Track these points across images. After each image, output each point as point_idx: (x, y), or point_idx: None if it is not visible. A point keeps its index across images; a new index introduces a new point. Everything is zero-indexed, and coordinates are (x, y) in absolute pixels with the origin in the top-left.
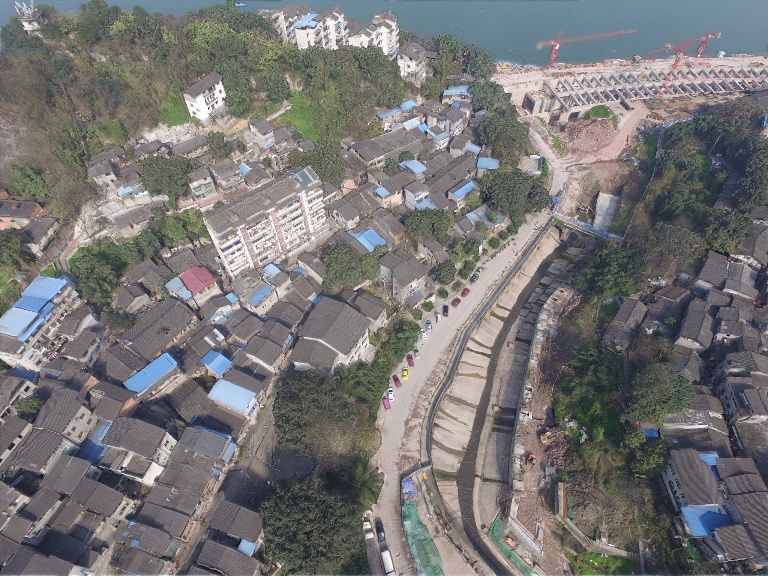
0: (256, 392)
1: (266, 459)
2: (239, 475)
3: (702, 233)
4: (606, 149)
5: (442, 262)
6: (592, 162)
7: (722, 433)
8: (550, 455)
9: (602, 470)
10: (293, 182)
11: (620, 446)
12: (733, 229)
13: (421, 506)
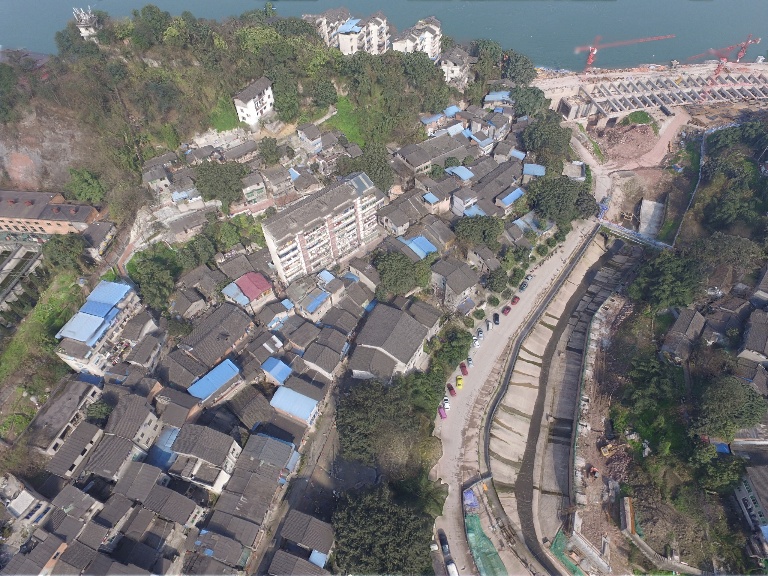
0: (318, 400)
1: (328, 468)
2: (302, 484)
3: (761, 243)
4: (647, 155)
5: (494, 270)
6: (634, 168)
7: None
8: (612, 468)
9: (669, 485)
10: (349, 188)
11: (689, 461)
12: None
13: (484, 518)
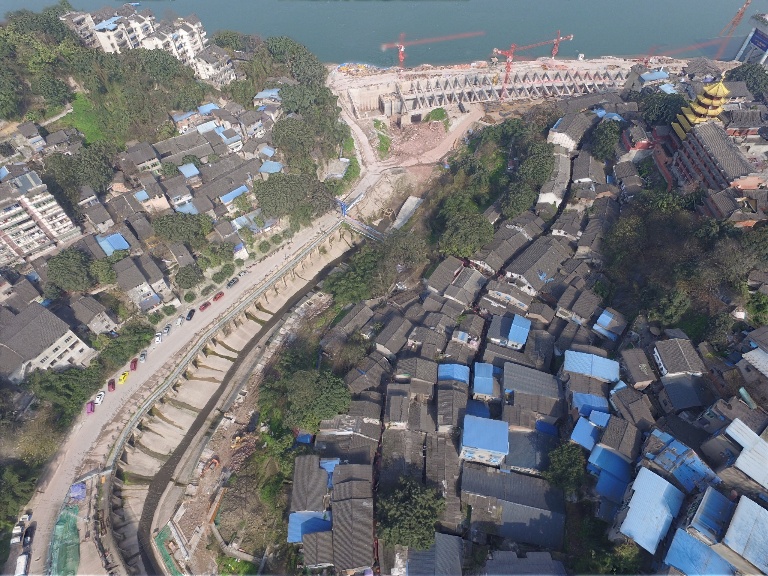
0: None
1: None
2: None
3: (441, 238)
4: (430, 152)
5: (184, 266)
6: (411, 165)
7: (371, 439)
8: (233, 460)
9: (266, 475)
10: (9, 187)
11: None
12: (464, 235)
13: (83, 510)
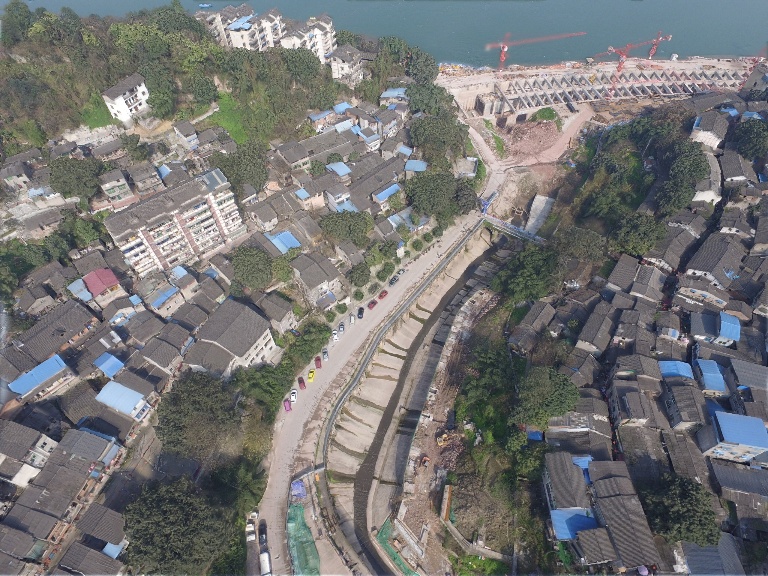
0: (144, 394)
1: (153, 461)
2: (123, 477)
3: (615, 236)
4: (548, 151)
5: (356, 264)
6: (532, 164)
7: (604, 436)
8: (444, 457)
9: (490, 473)
10: (199, 184)
11: (505, 449)
12: (643, 232)
13: (308, 508)
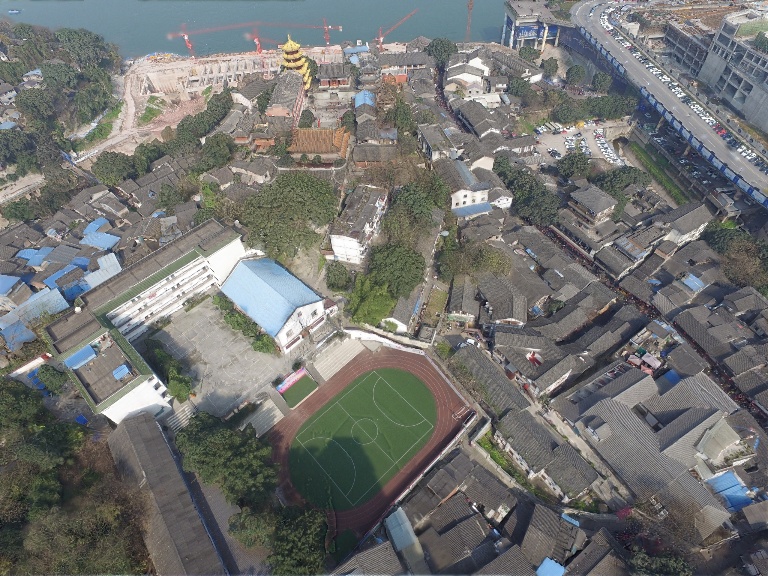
0: None
1: None
2: None
3: None
4: None
5: None
6: None
7: None
8: None
9: None
10: None
11: None
12: None
13: None
